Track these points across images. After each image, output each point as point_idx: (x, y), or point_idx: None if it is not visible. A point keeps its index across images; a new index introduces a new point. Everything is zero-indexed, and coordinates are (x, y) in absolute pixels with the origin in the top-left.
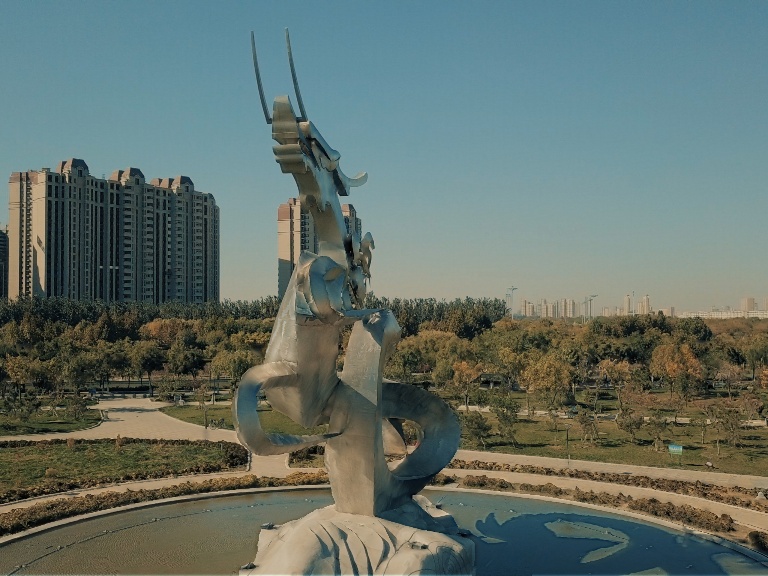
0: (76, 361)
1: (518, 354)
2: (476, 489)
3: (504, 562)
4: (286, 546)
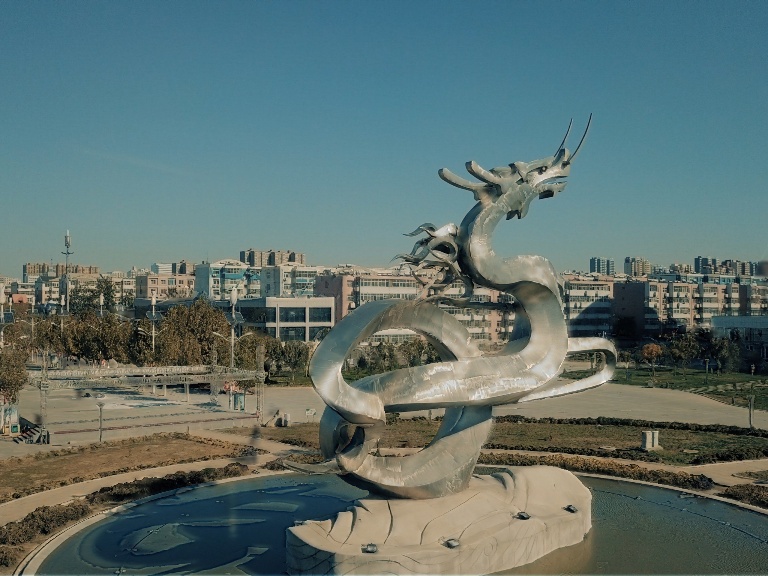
0: None
1: None
2: None
3: None
4: (559, 469)
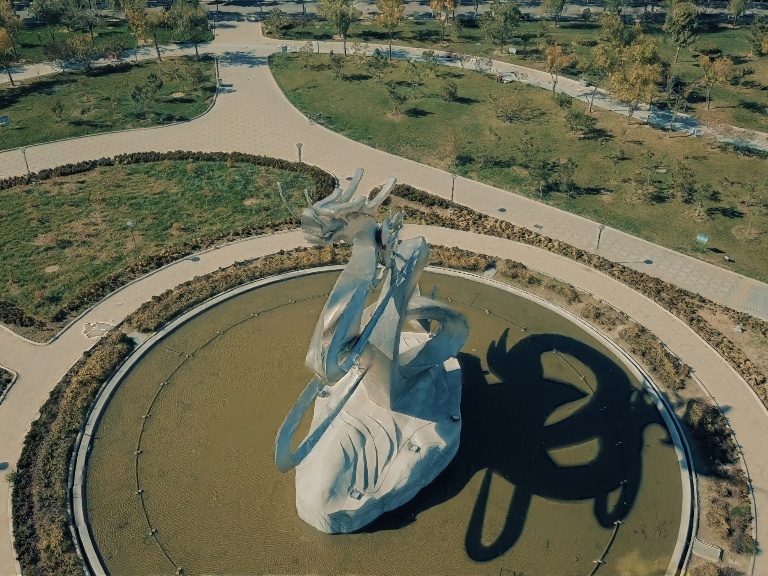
0: (188, 17)
1: (618, 36)
2: (507, 286)
3: (500, 391)
4: (322, 461)
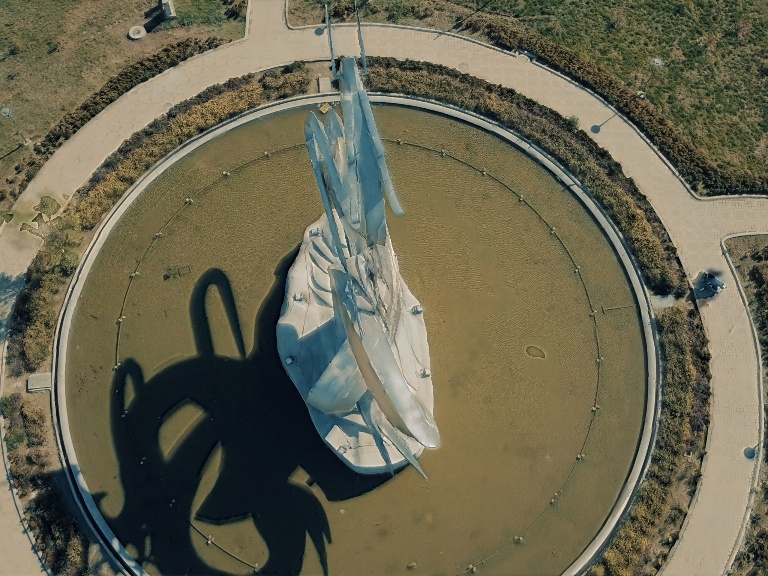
0: None
1: None
2: None
3: None
4: None
